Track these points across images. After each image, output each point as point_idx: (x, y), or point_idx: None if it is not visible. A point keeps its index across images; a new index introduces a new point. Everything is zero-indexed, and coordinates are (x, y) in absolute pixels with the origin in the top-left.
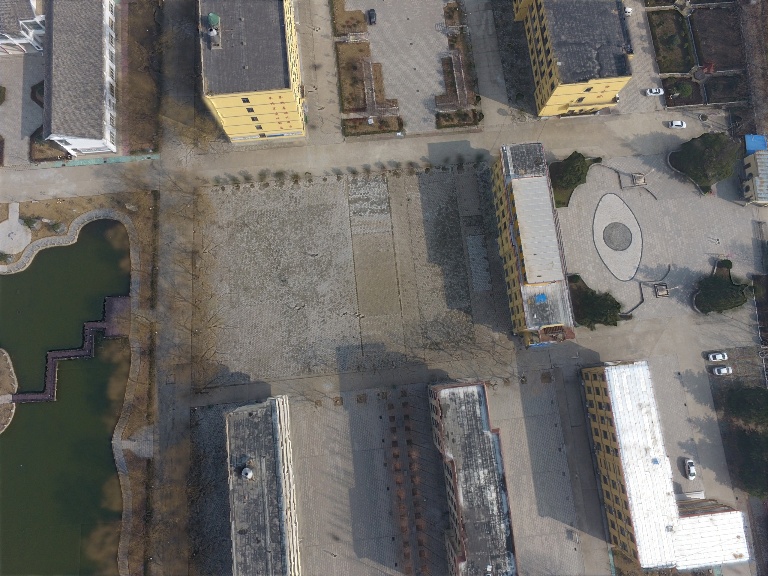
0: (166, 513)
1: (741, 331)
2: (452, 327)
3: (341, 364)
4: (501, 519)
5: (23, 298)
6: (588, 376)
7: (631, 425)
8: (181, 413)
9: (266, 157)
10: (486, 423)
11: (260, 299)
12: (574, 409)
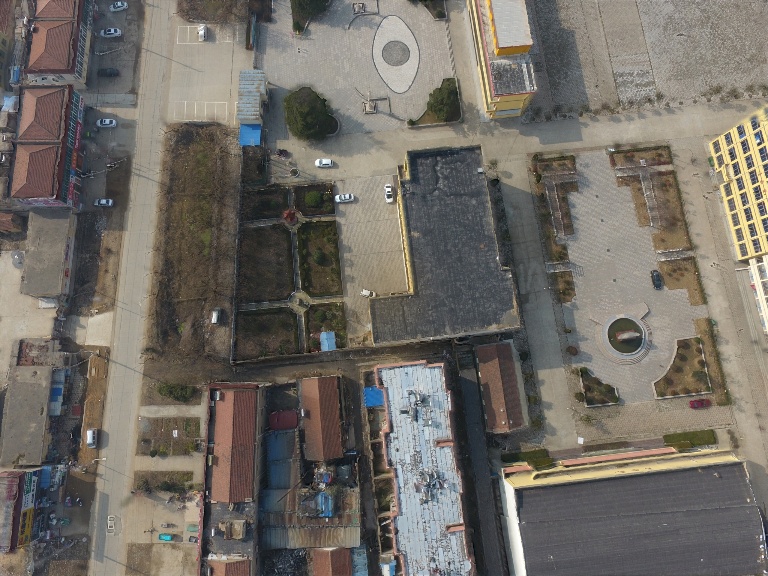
0: None
1: None
2: None
3: None
4: None
5: None
6: None
7: None
8: None
9: None
10: None
11: None
12: None
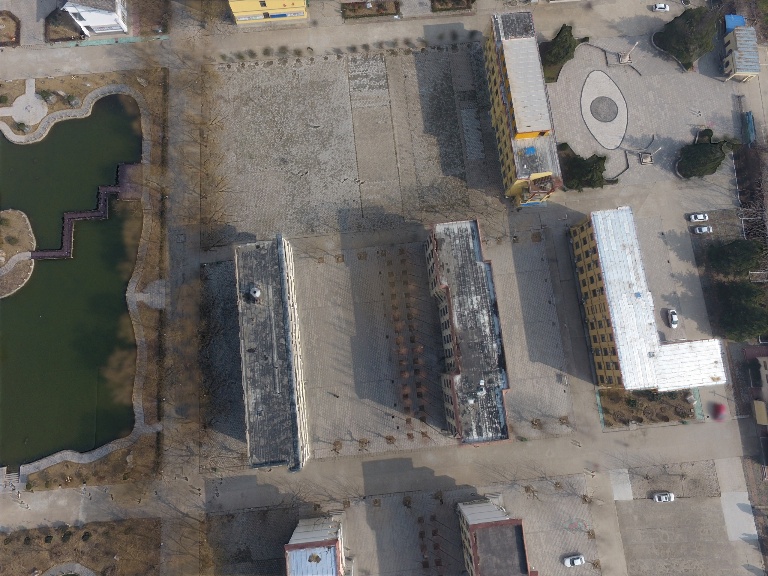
0: (178, 358)
1: (721, 195)
2: (447, 192)
3: (342, 225)
4: (493, 339)
5: (40, 166)
6: (576, 232)
7: (615, 263)
8: (191, 269)
9: (270, 38)
10: (479, 255)
11: (265, 166)
12: (563, 265)
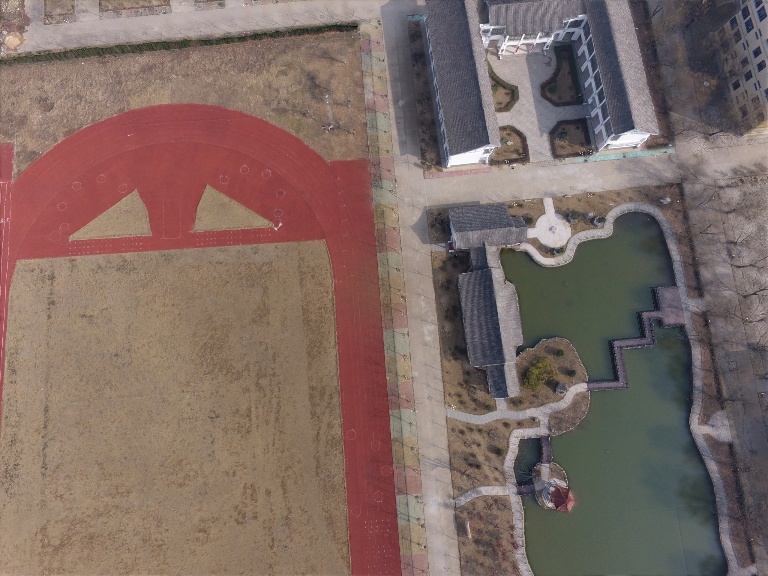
0: (757, 495)
1: None
2: None
3: None
4: None
5: (572, 290)
6: None
7: None
8: (750, 398)
9: None
10: None
11: None
12: None
